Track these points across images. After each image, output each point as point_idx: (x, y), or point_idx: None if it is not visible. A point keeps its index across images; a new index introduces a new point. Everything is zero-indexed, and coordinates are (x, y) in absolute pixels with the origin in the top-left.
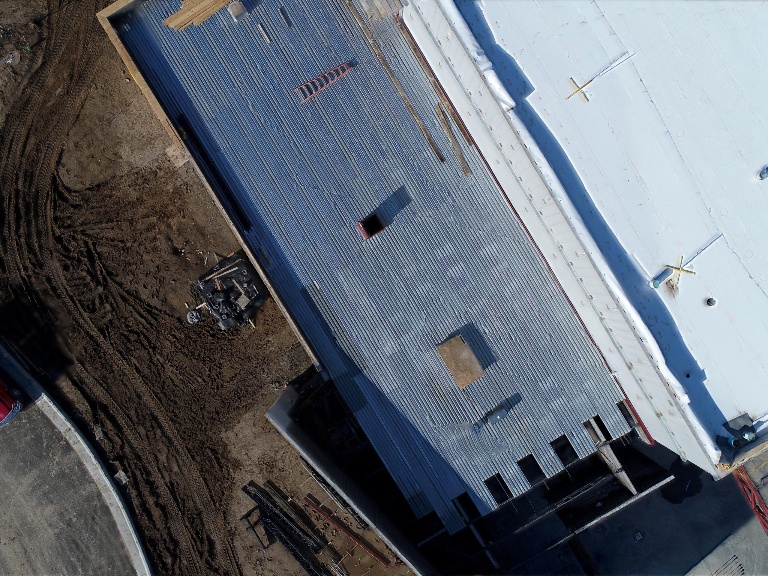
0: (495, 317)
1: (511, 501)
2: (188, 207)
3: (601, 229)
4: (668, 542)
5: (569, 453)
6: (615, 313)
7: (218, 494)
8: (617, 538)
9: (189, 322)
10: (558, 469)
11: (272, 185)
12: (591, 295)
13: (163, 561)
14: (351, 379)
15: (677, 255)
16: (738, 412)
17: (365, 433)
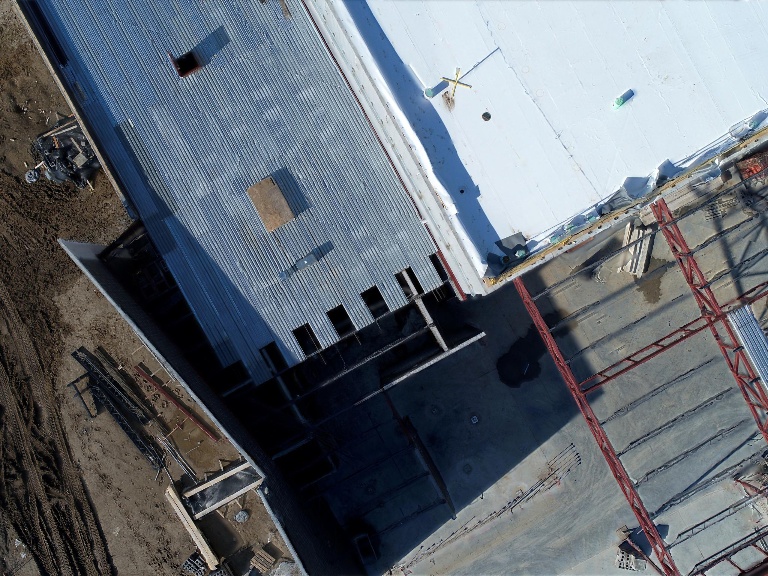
0: (309, 163)
1: (320, 353)
2: (32, 65)
3: (377, 37)
4: (504, 427)
5: (380, 306)
6: (388, 122)
7: (47, 359)
8: (453, 421)
9: (27, 181)
10: (368, 321)
11: (90, 20)
12: (381, 119)
13: None
14: (162, 220)
15: (454, 67)
16: (512, 231)
17: (174, 277)
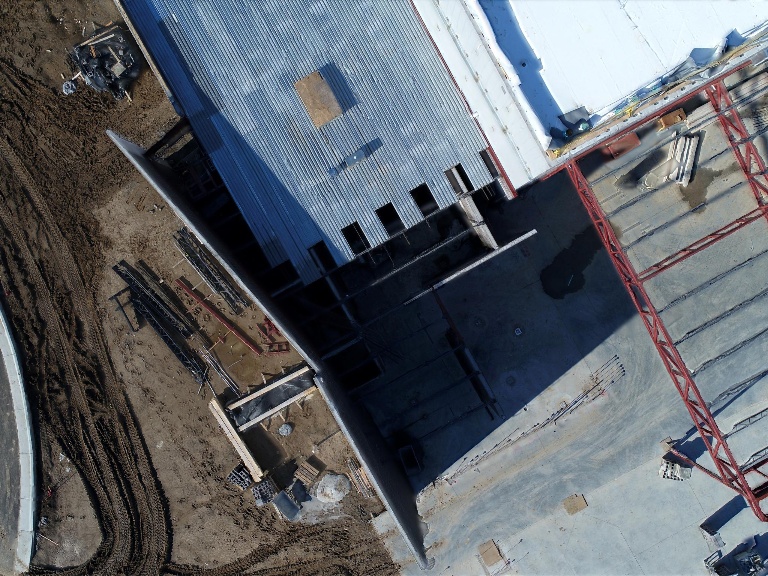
0: (357, 58)
1: (369, 252)
2: None
3: None
4: (548, 339)
5: (430, 204)
6: None
7: (88, 273)
8: (496, 333)
9: (64, 93)
10: (418, 219)
11: None
12: None
13: (30, 342)
14: (208, 118)
15: None
16: (575, 105)
17: (220, 176)
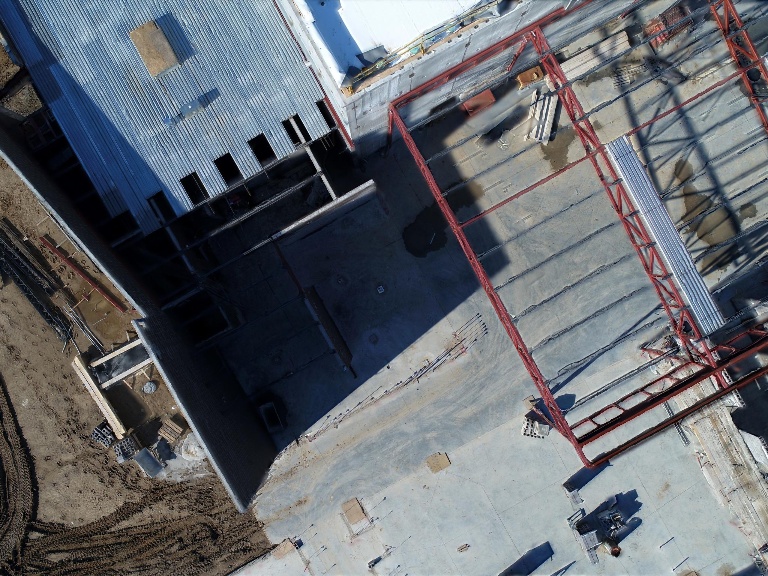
0: (195, 8)
1: (208, 203)
2: None
3: None
4: (410, 297)
5: (268, 154)
6: None
7: None
8: (359, 291)
9: None
10: (256, 169)
11: None
12: None
13: None
14: (47, 69)
15: None
16: (373, 44)
17: (60, 126)
